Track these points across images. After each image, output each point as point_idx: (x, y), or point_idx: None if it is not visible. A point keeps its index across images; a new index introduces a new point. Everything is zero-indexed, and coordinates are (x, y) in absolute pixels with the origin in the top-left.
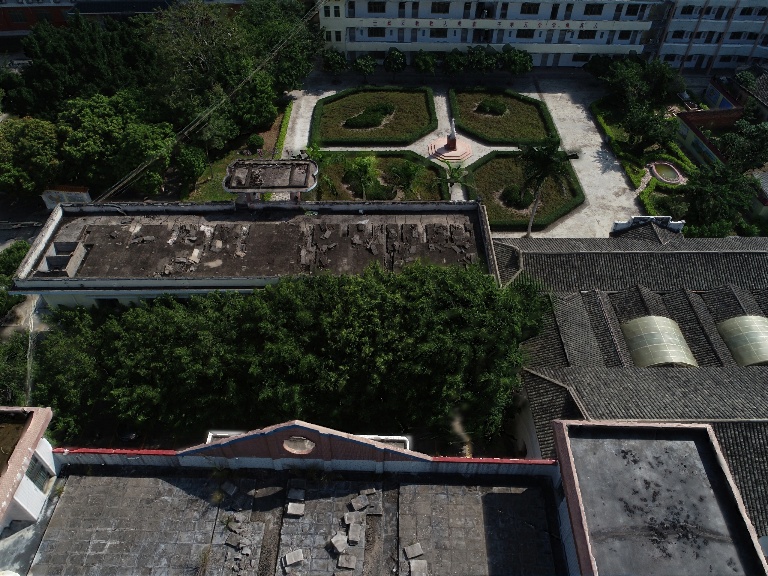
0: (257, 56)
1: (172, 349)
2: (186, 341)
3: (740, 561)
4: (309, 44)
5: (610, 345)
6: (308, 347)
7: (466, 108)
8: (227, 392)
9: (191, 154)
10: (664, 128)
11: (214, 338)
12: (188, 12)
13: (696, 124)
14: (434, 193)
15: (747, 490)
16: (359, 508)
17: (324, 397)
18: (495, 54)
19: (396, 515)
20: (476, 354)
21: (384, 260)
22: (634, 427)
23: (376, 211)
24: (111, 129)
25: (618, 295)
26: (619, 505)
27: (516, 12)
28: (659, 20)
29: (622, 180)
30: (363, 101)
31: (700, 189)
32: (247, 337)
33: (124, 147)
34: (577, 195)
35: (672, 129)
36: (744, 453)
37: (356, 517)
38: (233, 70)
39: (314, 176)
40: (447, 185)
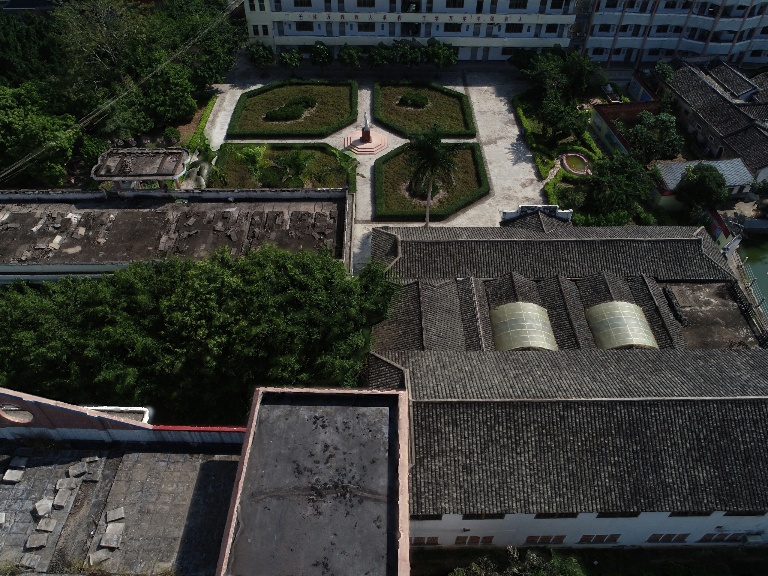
0: (173, 49)
1: (19, 333)
2: (35, 325)
3: (387, 519)
4: (230, 38)
5: (474, 331)
6: (151, 331)
7: (389, 101)
8: (71, 375)
9: (94, 146)
10: (574, 120)
11: (60, 322)
12: (90, 5)
13: (611, 116)
14: (341, 184)
15: (558, 468)
16: (74, 474)
17: (166, 380)
18: (420, 48)
19: (112, 481)
20: (311, 337)
21: (242, 246)
22: (335, 394)
23: (246, 199)
24: (11, 121)
25: (493, 282)
26: (291, 467)
27: (441, 6)
28: (583, 13)
29: (531, 171)
30: (287, 94)
31: (597, 179)
32: (93, 321)
33: (22, 138)
34: (482, 186)
35: (582, 121)
36: (559, 432)
37: (68, 483)
38: (144, 63)
39: (183, 164)
40: (355, 176)
